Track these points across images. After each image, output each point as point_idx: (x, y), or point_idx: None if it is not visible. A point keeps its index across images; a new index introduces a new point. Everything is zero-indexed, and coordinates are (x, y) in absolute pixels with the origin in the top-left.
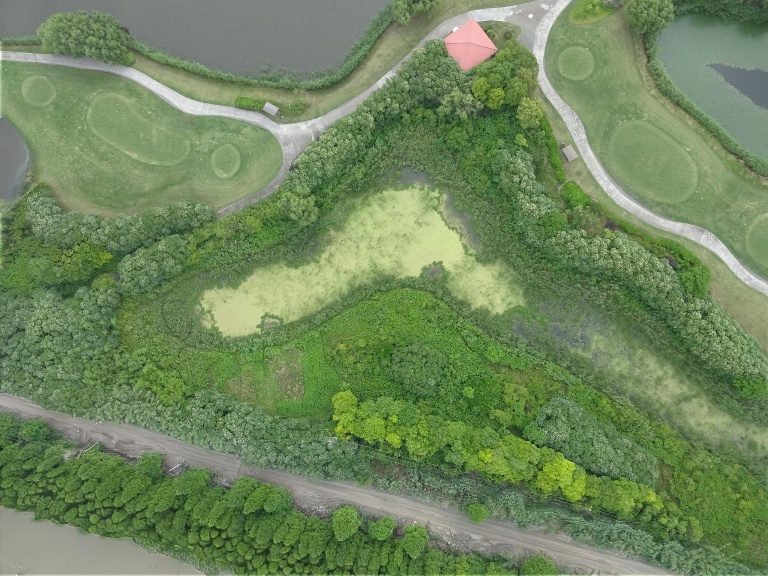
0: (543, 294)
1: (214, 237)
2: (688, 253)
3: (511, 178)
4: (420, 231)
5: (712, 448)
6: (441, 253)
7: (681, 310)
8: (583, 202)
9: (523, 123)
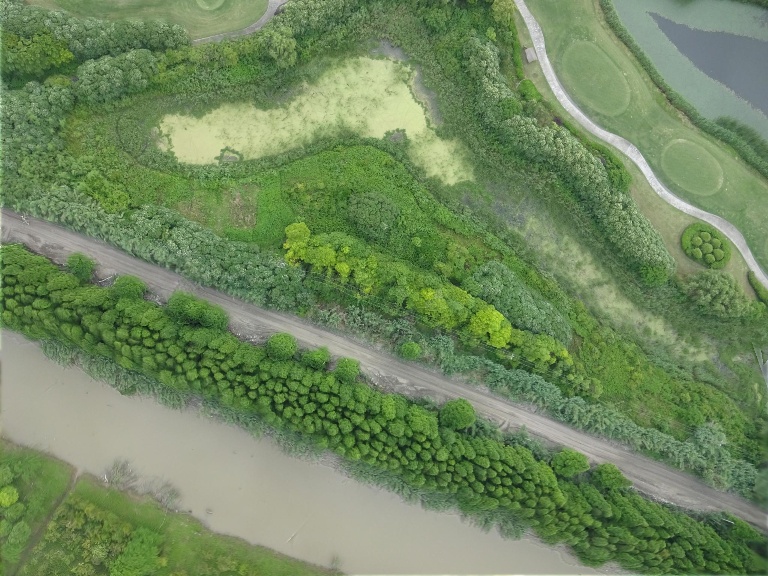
0: (491, 173)
1: (186, 62)
2: (616, 158)
3: (479, 63)
4: (389, 99)
5: (615, 328)
6: (405, 122)
7: (607, 200)
8: (537, 98)
9: (497, 15)
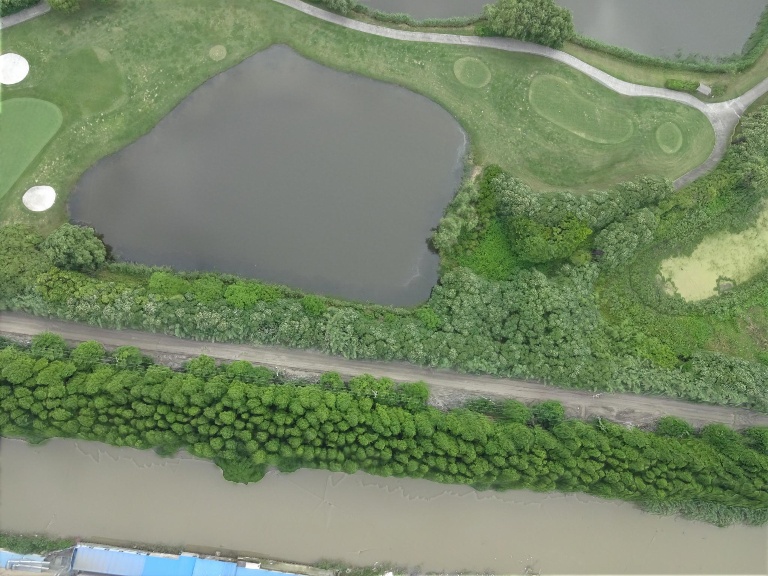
0: None
1: (674, 208)
2: None
3: None
4: None
5: None
6: None
7: None
8: None
9: None
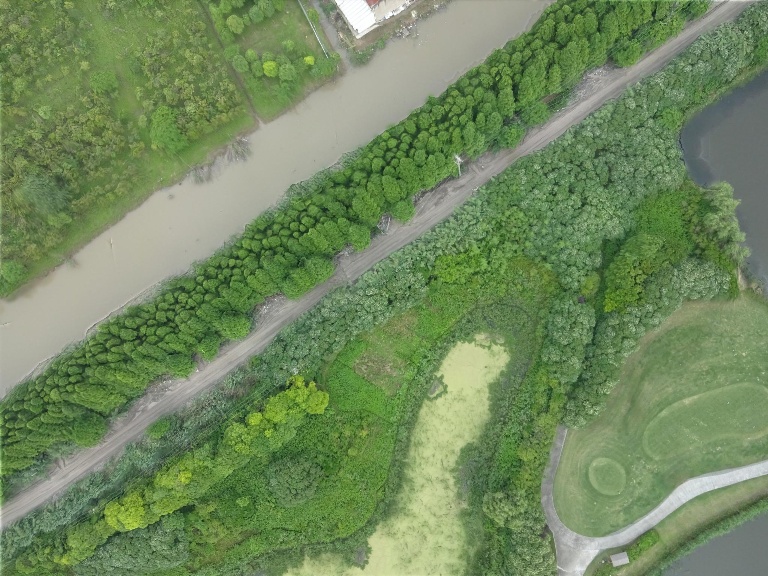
0: None
1: (546, 409)
2: None
3: None
4: None
5: None
6: (370, 575)
7: None
8: None
9: None
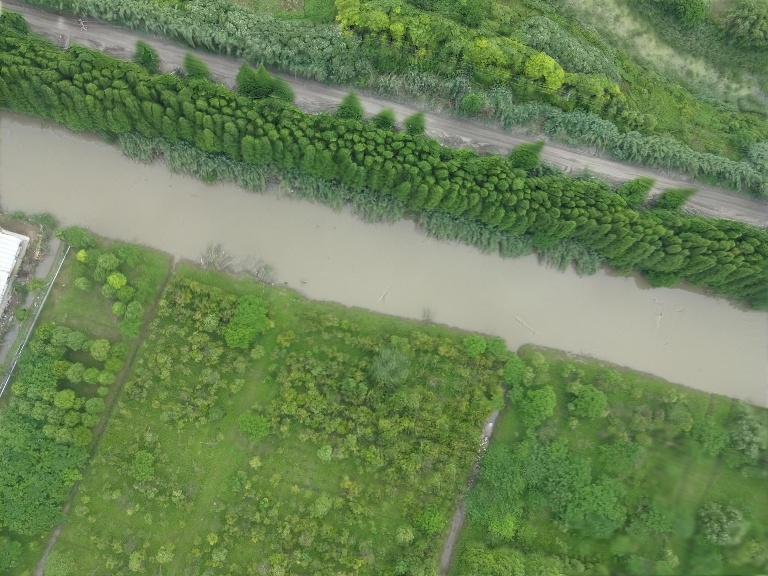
0: None
1: None
2: None
3: None
4: None
5: (659, 73)
6: None
7: None
8: None
9: None
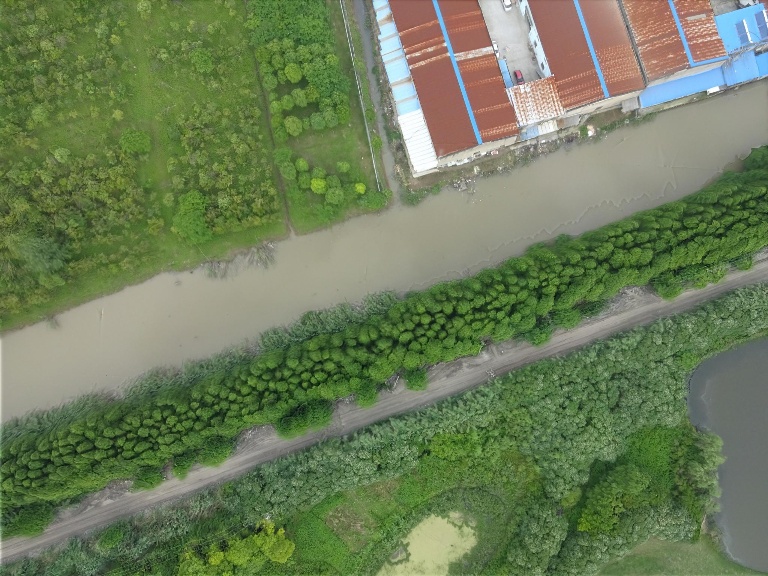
0: None
1: None
2: None
3: None
4: None
5: None
6: None
7: None
8: None
9: None
